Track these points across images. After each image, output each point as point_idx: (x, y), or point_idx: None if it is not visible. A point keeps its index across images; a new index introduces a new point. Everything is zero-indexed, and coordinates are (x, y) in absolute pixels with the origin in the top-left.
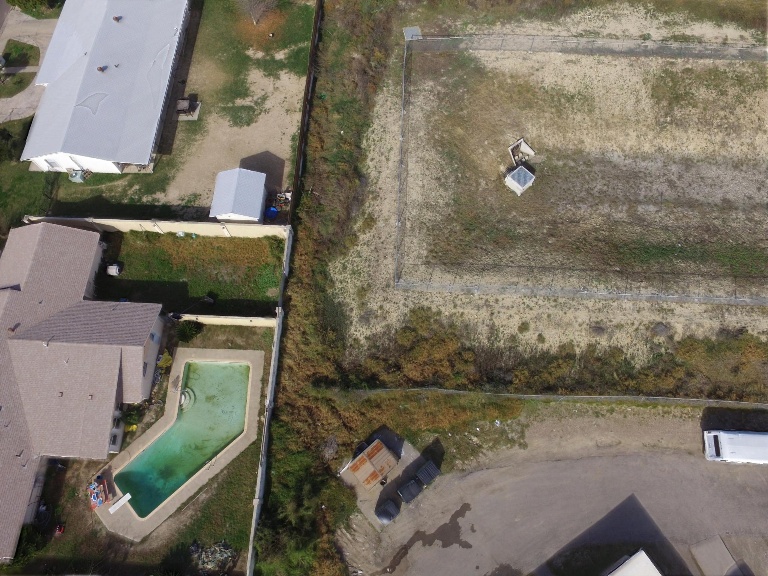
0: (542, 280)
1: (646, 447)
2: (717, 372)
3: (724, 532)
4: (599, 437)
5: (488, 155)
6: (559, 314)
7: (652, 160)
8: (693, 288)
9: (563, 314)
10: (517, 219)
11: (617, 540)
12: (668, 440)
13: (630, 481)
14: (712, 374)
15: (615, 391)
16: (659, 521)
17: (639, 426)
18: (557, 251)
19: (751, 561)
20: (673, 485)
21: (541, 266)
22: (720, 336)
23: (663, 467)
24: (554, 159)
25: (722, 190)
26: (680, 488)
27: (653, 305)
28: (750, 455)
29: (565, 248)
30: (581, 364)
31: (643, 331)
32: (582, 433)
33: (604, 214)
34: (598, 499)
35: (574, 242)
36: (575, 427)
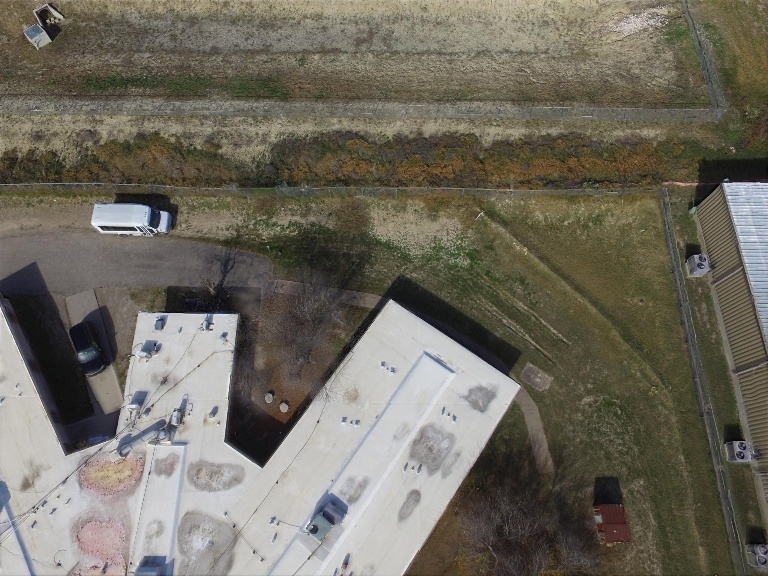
0: (4, 102)
1: (61, 228)
2: (130, 168)
3: (98, 287)
4: (25, 222)
5: (12, 16)
6: (8, 127)
7: (163, 19)
8: (127, 104)
9: (11, 127)
10: (24, 65)
11: (7, 294)
12: (81, 222)
13: (37, 253)
14: (126, 170)
15: (34, 182)
16: (48, 280)
17: (60, 213)
18: (35, 84)
19: (112, 307)
20: (71, 255)
21: (11, 93)
22: (135, 139)
23: (68, 242)
24: (79, 21)
25: (214, 40)
26: (76, 257)
27: (88, 118)
28: (111, 219)
29: (43, 82)
30: (21, 166)
31: (74, 138)
32: (12, 220)
33: (102, 60)
34: (5, 266)
35: (56, 78)
36: (7, 215)
